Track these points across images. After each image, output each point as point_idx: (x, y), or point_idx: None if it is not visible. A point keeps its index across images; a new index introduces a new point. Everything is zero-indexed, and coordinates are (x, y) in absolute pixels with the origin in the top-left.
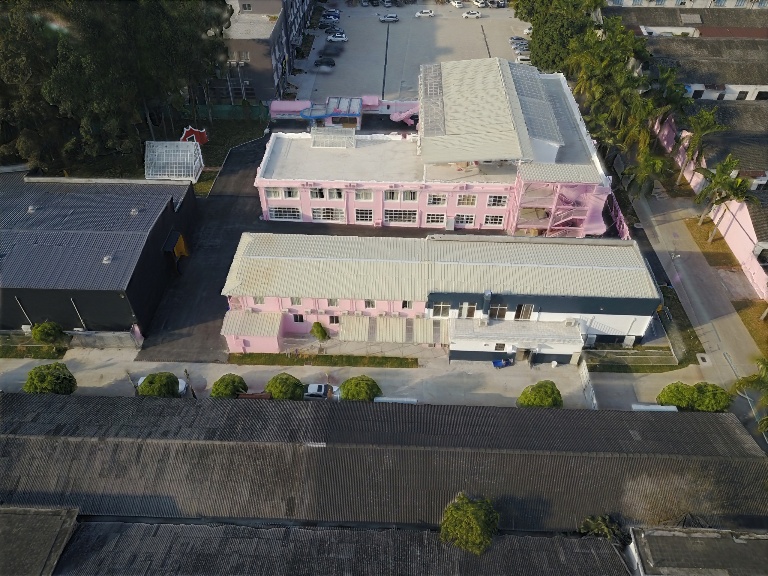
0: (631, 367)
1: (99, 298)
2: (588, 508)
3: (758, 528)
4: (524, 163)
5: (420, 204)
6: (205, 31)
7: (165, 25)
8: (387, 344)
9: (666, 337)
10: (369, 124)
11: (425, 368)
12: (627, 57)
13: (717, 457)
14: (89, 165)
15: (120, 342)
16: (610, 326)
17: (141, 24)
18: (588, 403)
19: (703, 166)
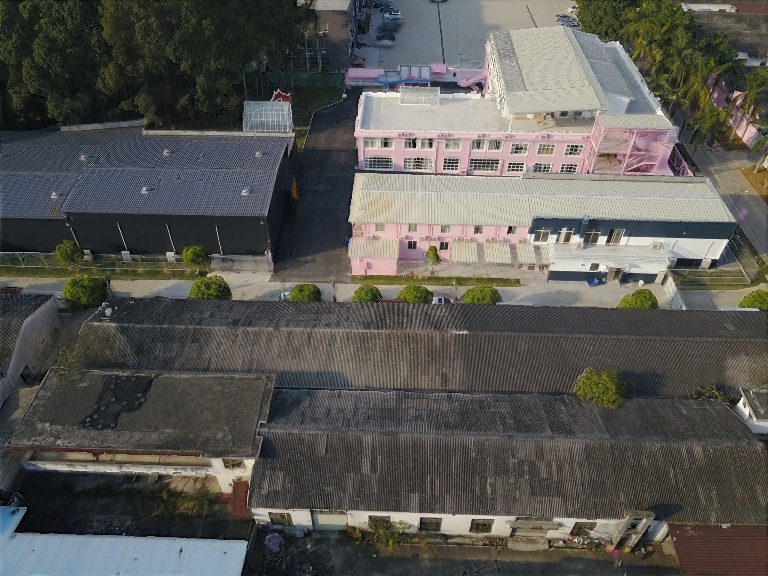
0: (709, 286)
1: (241, 225)
2: (697, 380)
3: None
4: (602, 113)
5: (503, 153)
6: None
7: None
8: (490, 268)
9: (737, 262)
10: None
11: (527, 287)
12: None
13: None
14: (187, 125)
15: (255, 266)
16: (690, 250)
17: None
18: None
19: None
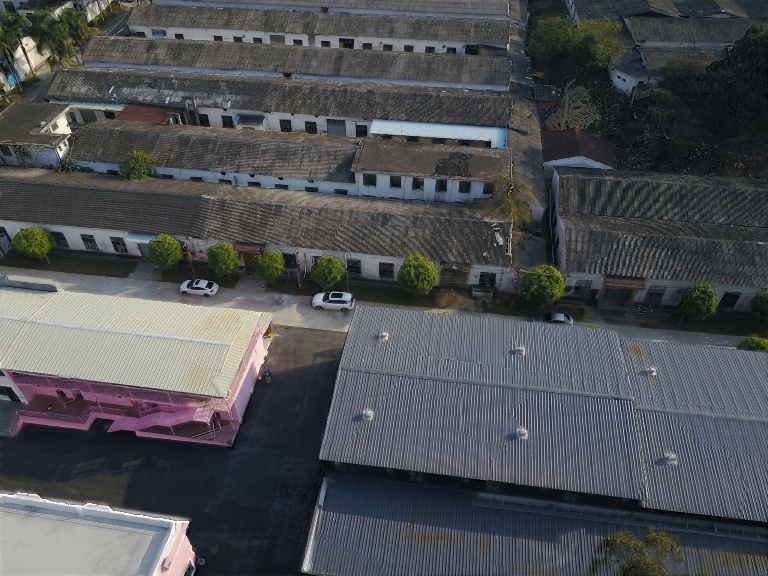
0: None
1: None
2: None
3: None
4: None
5: None
6: None
7: None
8: None
9: None
10: None
11: None
12: None
13: None
14: None
15: None
16: None
17: None
18: None
19: None
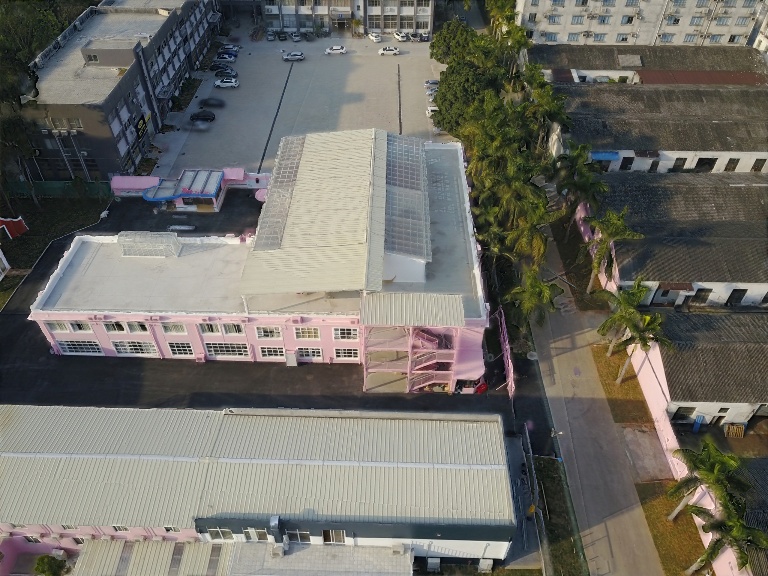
0: None
1: None
2: None
3: None
4: (371, 293)
5: (248, 337)
6: None
7: None
8: None
9: (539, 552)
10: (232, 203)
11: None
12: (543, 118)
13: None
14: None
15: None
16: (457, 549)
17: None
18: None
19: (616, 275)
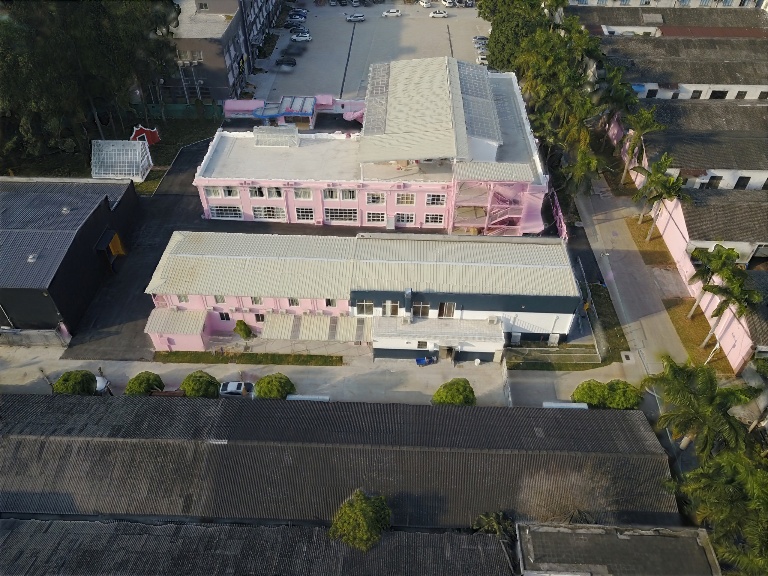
0: (554, 365)
1: (23, 296)
2: (483, 505)
3: (651, 524)
4: (459, 162)
5: (359, 203)
6: (153, 30)
7: (106, 24)
8: (313, 342)
9: (592, 335)
10: (323, 123)
11: (349, 366)
12: (581, 56)
13: (616, 454)
14: (38, 164)
15: (46, 340)
16: (534, 324)
17: (80, 23)
18: (507, 401)
19: (645, 165)
